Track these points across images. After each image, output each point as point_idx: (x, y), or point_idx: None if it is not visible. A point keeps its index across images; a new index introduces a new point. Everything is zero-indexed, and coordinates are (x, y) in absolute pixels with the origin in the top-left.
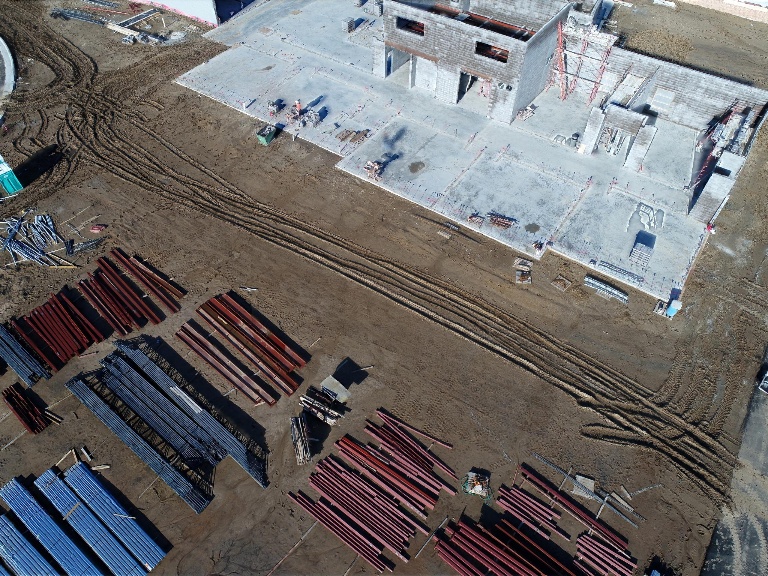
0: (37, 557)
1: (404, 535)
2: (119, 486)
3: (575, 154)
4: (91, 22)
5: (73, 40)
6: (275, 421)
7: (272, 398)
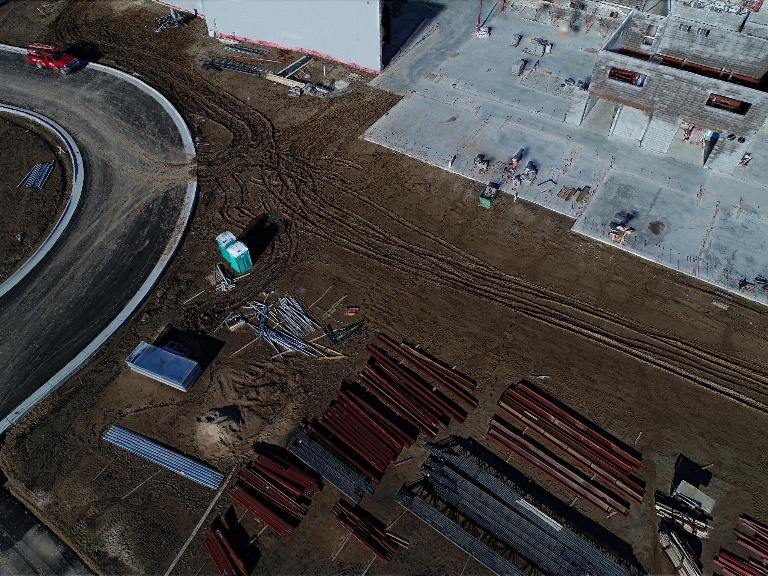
0: None
1: None
2: None
3: None
4: (246, 73)
5: (235, 93)
6: (637, 535)
7: (624, 508)
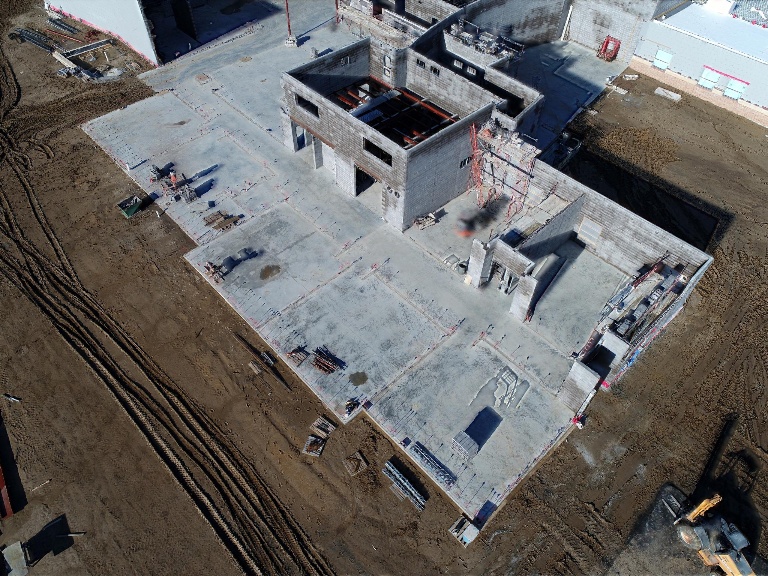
0: None
1: None
2: None
3: (459, 284)
4: (41, 47)
5: (15, 66)
6: None
7: None
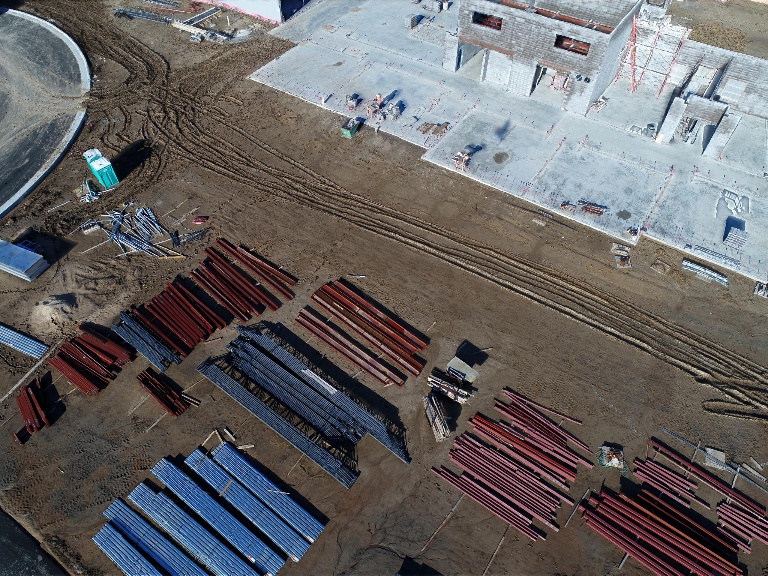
0: (202, 531)
1: (551, 506)
2: (266, 464)
3: (653, 144)
4: (156, 21)
5: (141, 39)
6: (406, 401)
7: (400, 379)
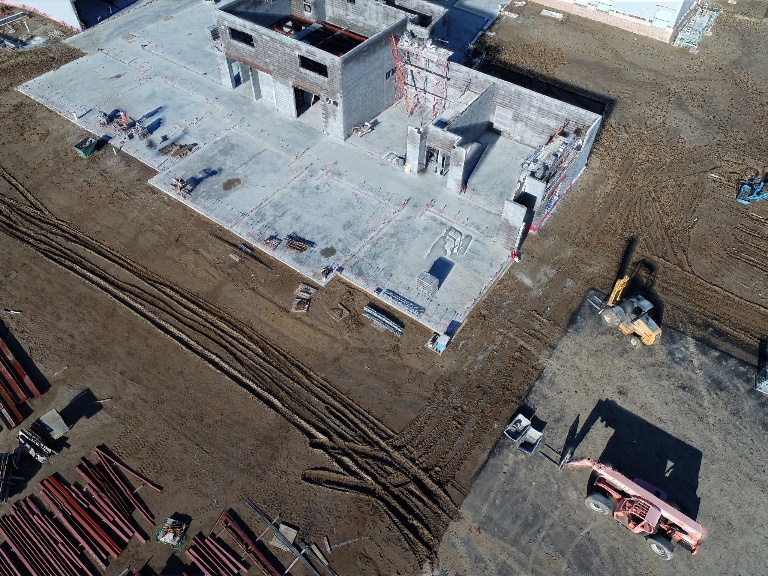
0: None
1: None
2: None
3: (401, 173)
4: None
5: None
6: None
7: None
